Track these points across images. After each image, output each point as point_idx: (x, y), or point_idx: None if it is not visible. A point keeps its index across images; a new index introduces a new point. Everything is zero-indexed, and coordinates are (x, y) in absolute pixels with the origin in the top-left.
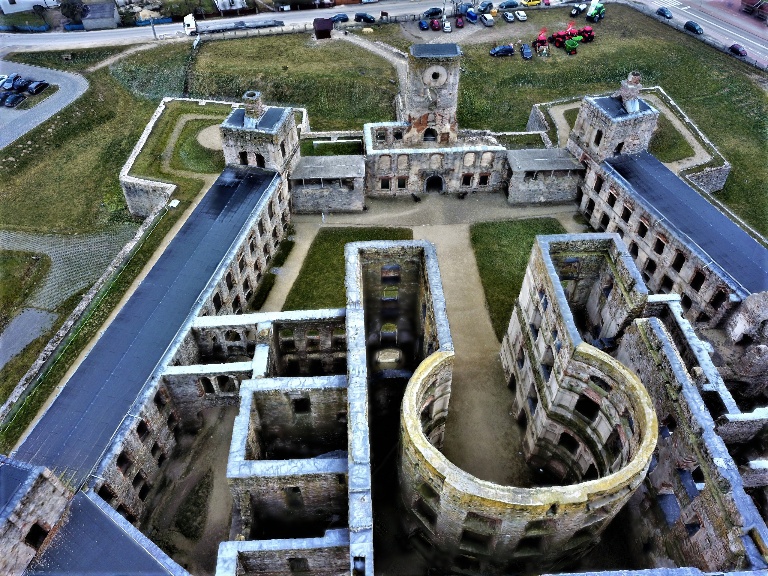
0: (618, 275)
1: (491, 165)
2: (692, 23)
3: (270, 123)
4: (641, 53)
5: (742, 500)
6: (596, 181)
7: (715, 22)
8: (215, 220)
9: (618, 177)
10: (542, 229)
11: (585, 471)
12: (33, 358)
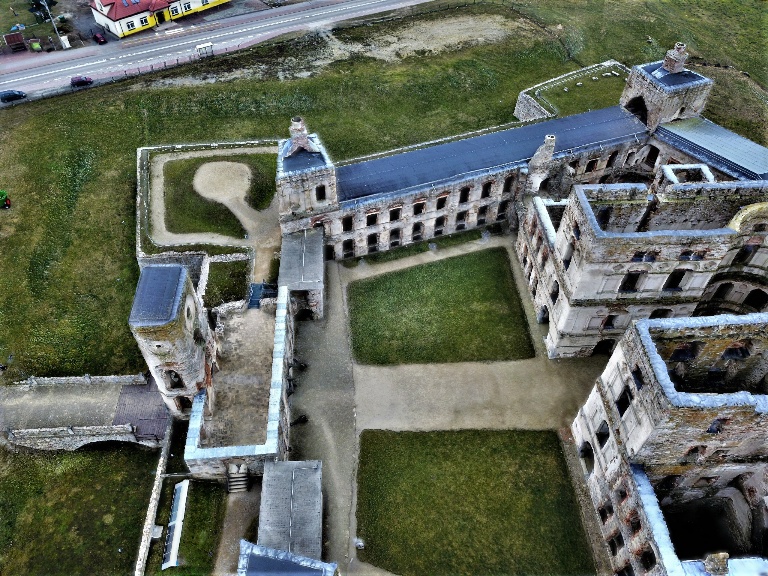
0: (612, 201)
1: (288, 313)
2: (7, 93)
3: (304, 575)
4: (42, 147)
5: None
6: (342, 224)
7: (3, 80)
8: None
9: (366, 199)
10: (366, 297)
11: (711, 297)
12: None
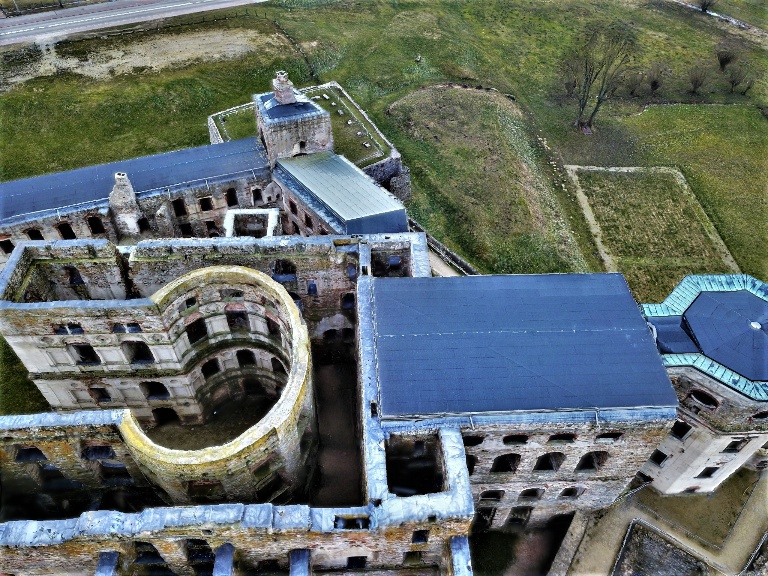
0: (70, 259)
1: None
2: None
3: None
4: None
5: (314, 240)
6: None
7: None
8: None
9: None
10: None
11: (237, 364)
12: None
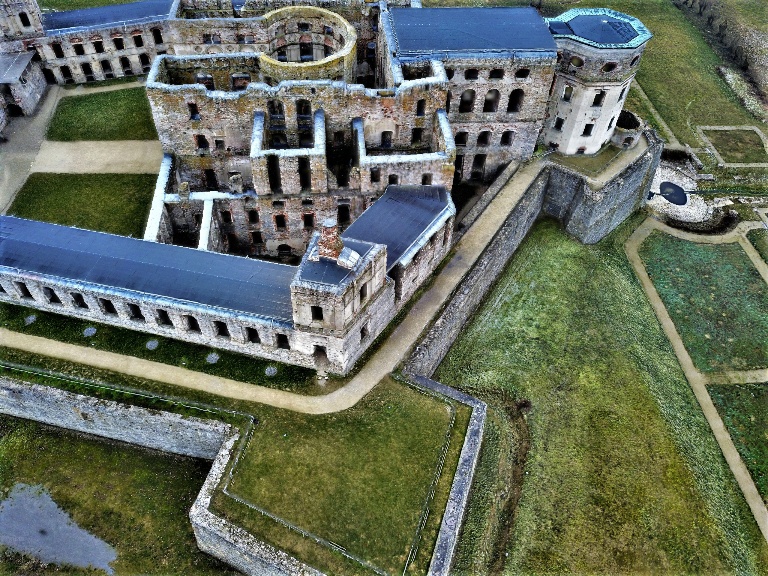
0: (206, 9)
1: None
2: None
3: None
4: None
5: None
6: (53, 50)
7: None
8: (5, 238)
9: (68, 30)
10: (72, 105)
11: None
12: (85, 489)
